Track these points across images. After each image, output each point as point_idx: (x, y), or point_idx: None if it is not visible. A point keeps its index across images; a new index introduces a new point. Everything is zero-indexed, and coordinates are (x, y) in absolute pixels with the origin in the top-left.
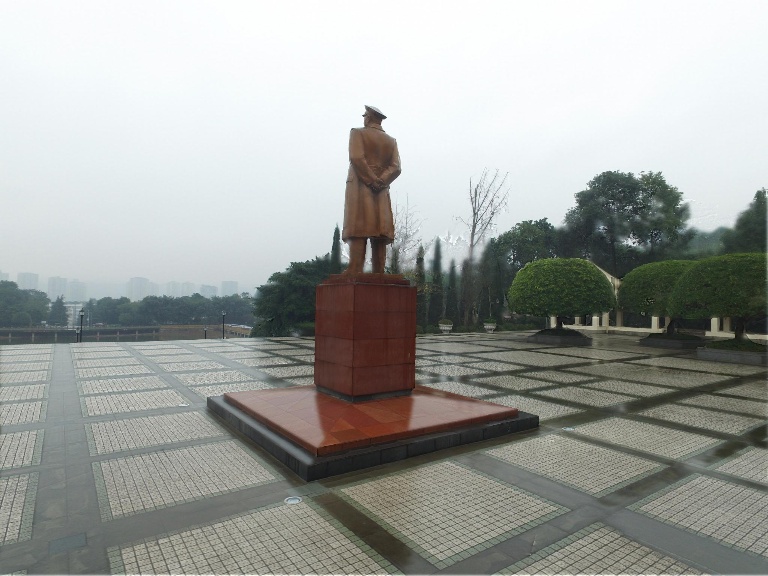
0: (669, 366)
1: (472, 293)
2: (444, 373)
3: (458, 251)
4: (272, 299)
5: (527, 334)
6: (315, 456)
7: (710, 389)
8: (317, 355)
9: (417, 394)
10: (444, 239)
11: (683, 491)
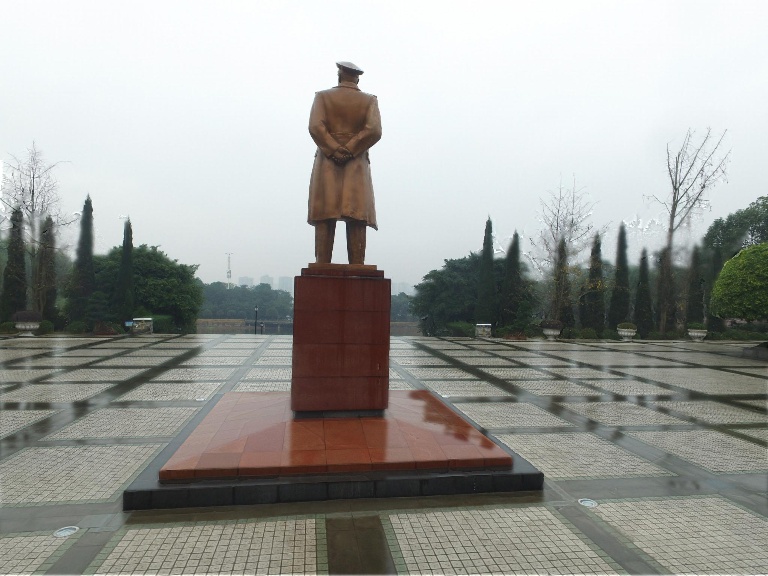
0: None
1: (671, 290)
2: (536, 391)
3: (651, 238)
4: (424, 297)
5: None
6: (156, 480)
7: None
8: None
9: (391, 417)
10: (631, 224)
11: None
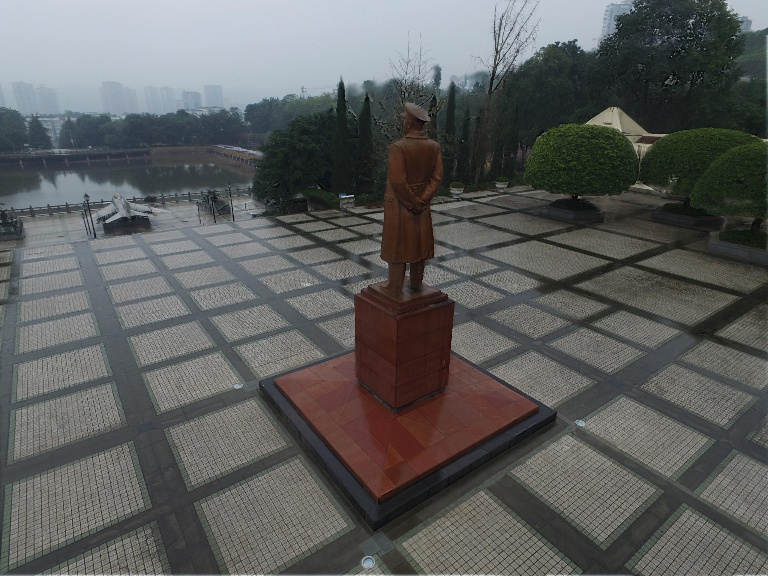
0: (678, 273)
1: (486, 148)
2: (463, 302)
3: (474, 99)
4: (276, 164)
5: (539, 195)
6: (377, 504)
7: (712, 327)
8: (358, 356)
9: (449, 389)
10: (460, 85)
11: (671, 536)
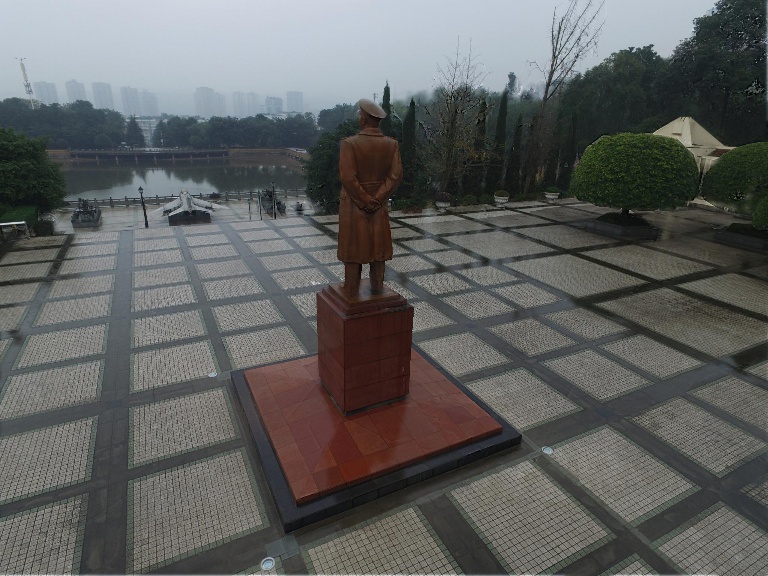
0: (723, 300)
1: (537, 157)
2: (467, 312)
3: (528, 106)
4: (321, 166)
5: (592, 207)
6: (295, 506)
7: (743, 362)
8: (320, 356)
9: (411, 398)
10: (513, 91)
11: None
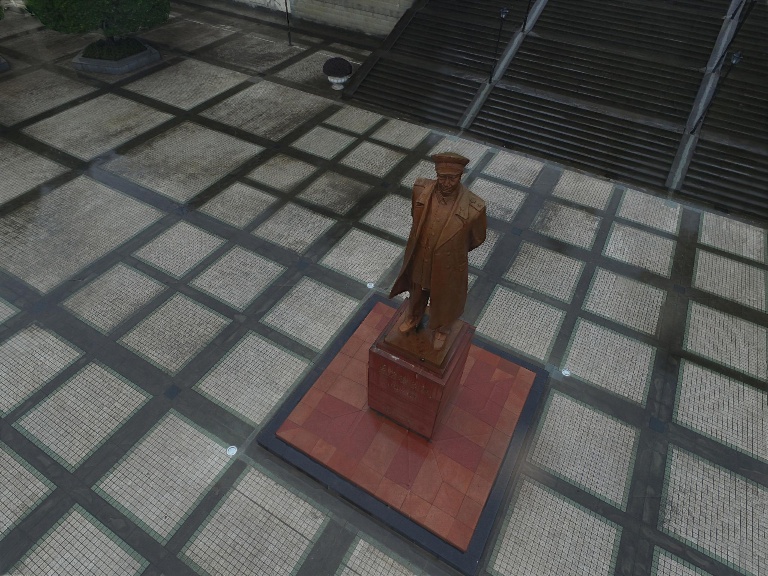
0: None
1: None
2: (124, 412)
3: None
4: None
5: None
6: (537, 376)
7: (167, 203)
8: None
9: None
10: None
11: None
